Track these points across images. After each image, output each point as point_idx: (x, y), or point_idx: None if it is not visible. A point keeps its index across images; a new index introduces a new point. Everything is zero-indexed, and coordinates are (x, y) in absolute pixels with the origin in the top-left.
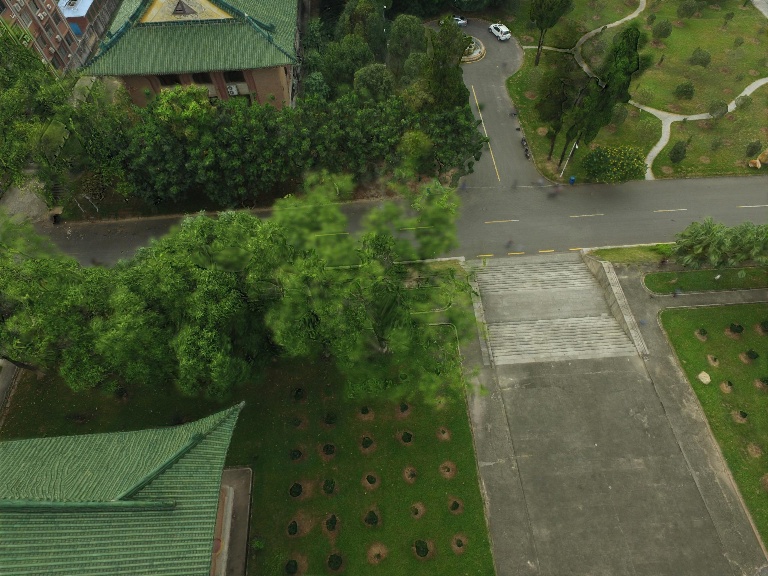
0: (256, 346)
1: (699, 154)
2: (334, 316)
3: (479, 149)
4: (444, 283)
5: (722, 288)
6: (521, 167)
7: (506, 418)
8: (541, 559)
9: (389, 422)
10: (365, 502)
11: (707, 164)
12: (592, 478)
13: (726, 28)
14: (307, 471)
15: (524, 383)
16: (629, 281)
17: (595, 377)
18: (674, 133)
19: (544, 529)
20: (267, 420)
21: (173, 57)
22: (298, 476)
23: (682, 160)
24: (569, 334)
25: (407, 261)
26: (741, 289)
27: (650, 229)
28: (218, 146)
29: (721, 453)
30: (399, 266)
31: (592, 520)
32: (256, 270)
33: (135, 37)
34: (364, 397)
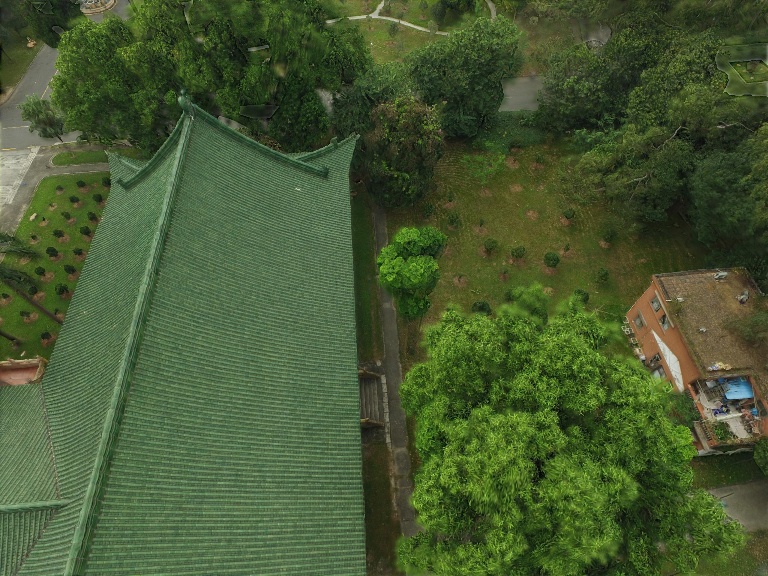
0: None
1: None
2: None
3: None
4: None
5: None
6: None
7: None
8: None
9: None
10: None
11: None
12: None
13: None
14: None
15: None
16: (42, 158)
17: None
18: None
19: None
20: None
21: None
22: None
23: None
24: None
25: None
26: None
27: None
28: None
29: None
30: None
31: None
32: None
33: None
34: None
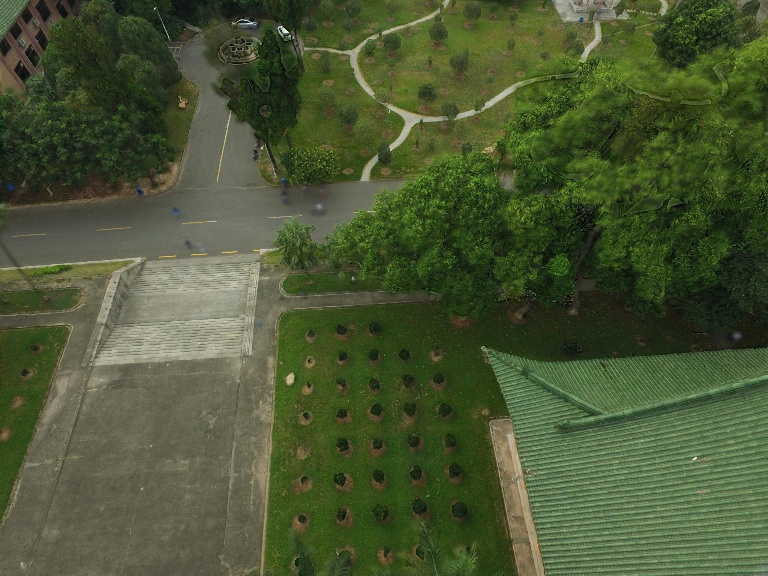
0: None
1: (426, 155)
2: None
3: (169, 150)
4: (84, 284)
5: (357, 289)
6: (245, 168)
7: (75, 419)
8: (35, 560)
9: None
10: None
11: (429, 165)
12: (129, 479)
13: (515, 29)
14: None
15: (112, 384)
16: (268, 282)
17: (186, 378)
18: (412, 134)
19: (54, 530)
20: None
21: None
22: None
23: (406, 161)
24: (190, 335)
25: (83, 262)
26: (376, 290)
27: None
28: None
29: (270, 455)
30: (60, 267)
31: (106, 522)
32: None
33: None
34: None
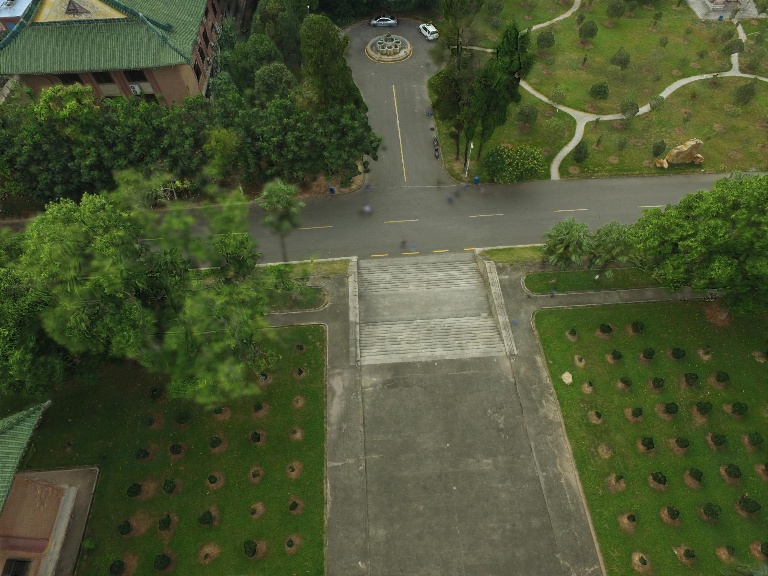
0: (79, 345)
1: (609, 154)
2: (103, 315)
3: (376, 149)
4: (324, 283)
5: (601, 288)
6: (429, 167)
7: (362, 418)
8: (372, 560)
9: (244, 422)
10: (206, 502)
11: (615, 164)
12: (438, 478)
13: (656, 28)
14: (153, 471)
15: (387, 383)
16: (509, 281)
17: (459, 377)
18: (587, 133)
19: (381, 530)
20: (122, 420)
21: (68, 56)
22: (143, 476)
23: (591, 160)
24: (443, 334)
25: (299, 261)
26: (620, 289)
27: (547, 229)
28: (104, 145)
29: (571, 454)
30: (286, 266)
31: (430, 521)
32: (46, 269)
33: (30, 36)
34: (223, 397)
